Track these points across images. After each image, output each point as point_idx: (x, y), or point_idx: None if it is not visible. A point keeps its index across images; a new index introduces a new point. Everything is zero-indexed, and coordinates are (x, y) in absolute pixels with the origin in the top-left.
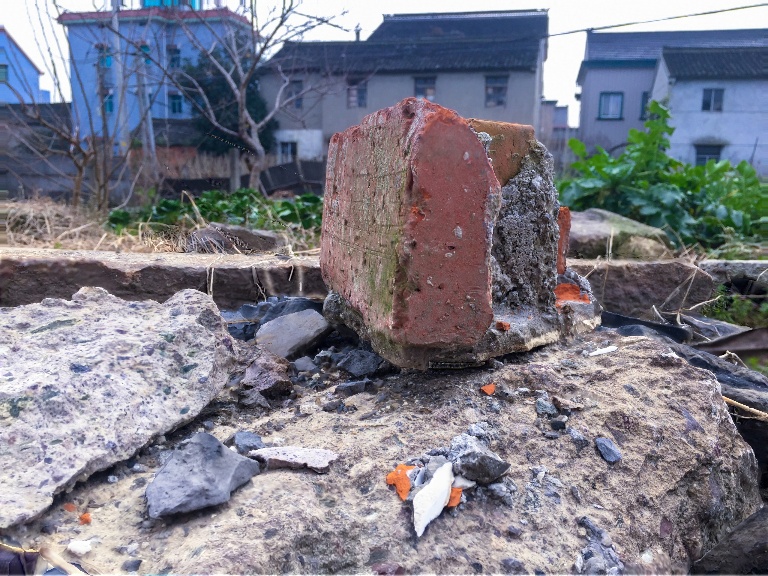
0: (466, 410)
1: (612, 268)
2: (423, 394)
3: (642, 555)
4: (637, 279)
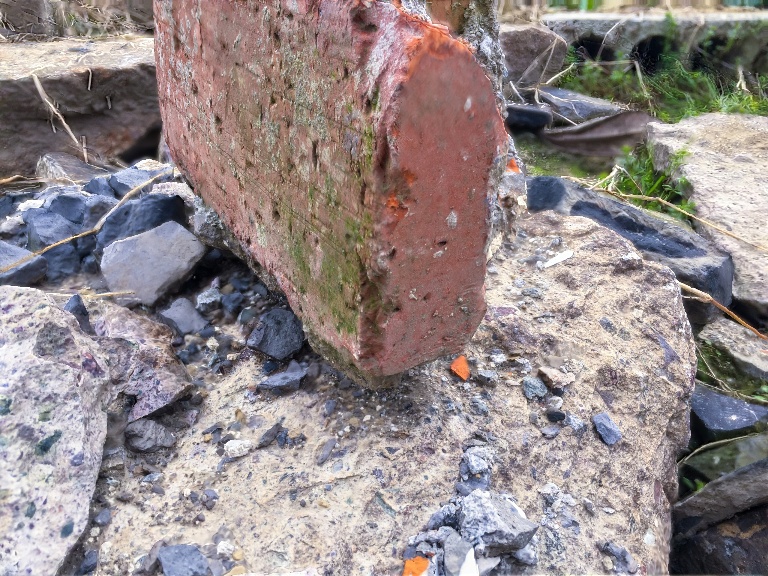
0: (451, 423)
1: None
2: (382, 391)
3: (644, 537)
4: None
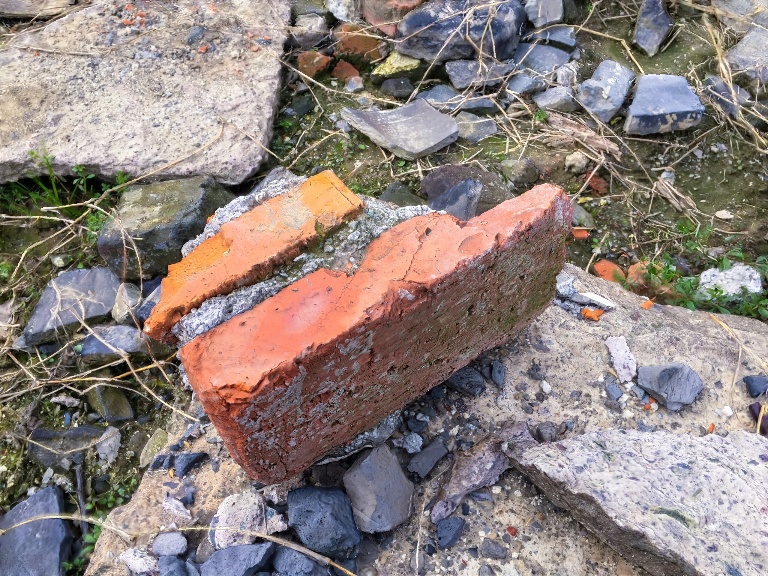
0: None
1: None
2: None
3: None
4: None
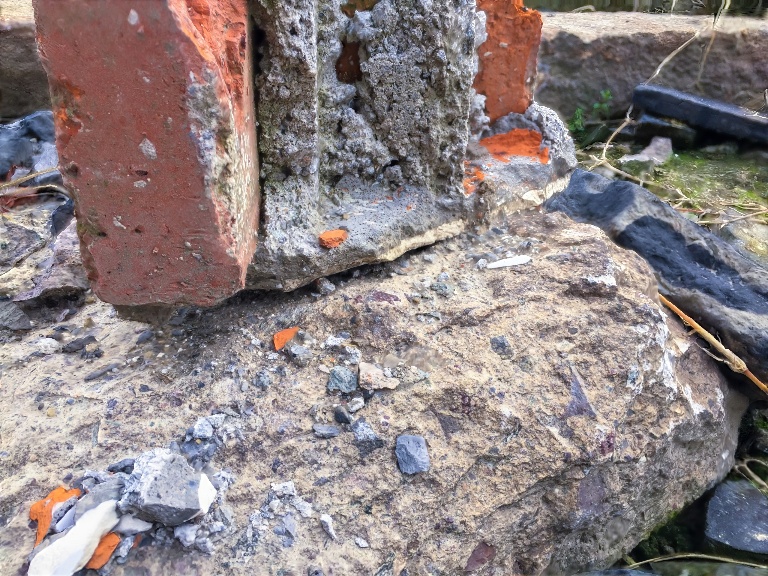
0: (219, 383)
1: (720, 36)
2: (197, 336)
3: None
4: (753, 51)
